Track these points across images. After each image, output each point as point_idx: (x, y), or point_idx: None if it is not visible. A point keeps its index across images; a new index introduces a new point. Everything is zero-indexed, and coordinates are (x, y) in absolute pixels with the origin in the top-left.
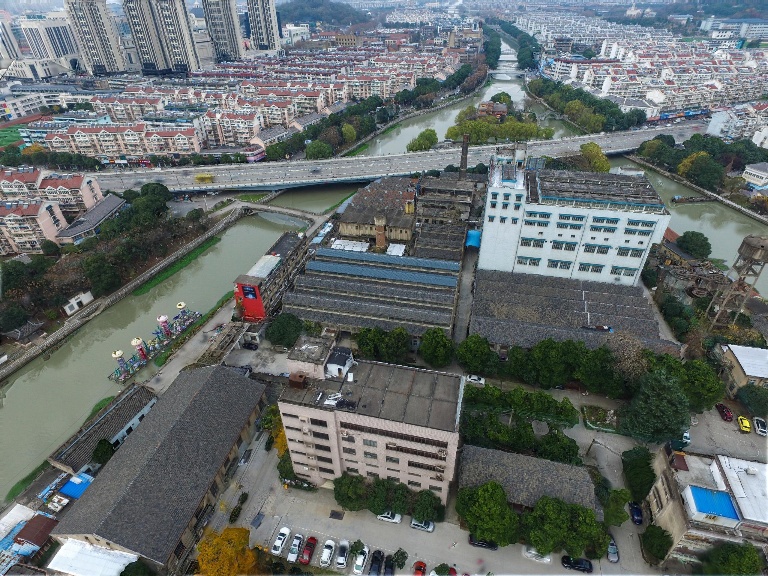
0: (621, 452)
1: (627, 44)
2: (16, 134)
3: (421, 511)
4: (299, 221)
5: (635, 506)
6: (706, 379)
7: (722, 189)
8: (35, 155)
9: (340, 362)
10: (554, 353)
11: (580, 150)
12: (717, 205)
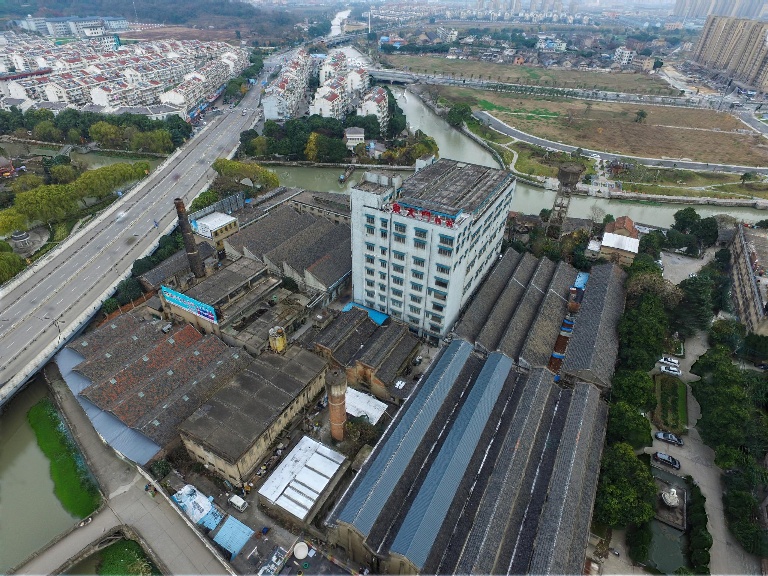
0: (705, 350)
1: (8, 50)
2: None
3: None
4: (72, 570)
5: (767, 366)
6: (658, 269)
7: (349, 158)
8: None
9: None
10: None
11: (224, 171)
12: (357, 172)
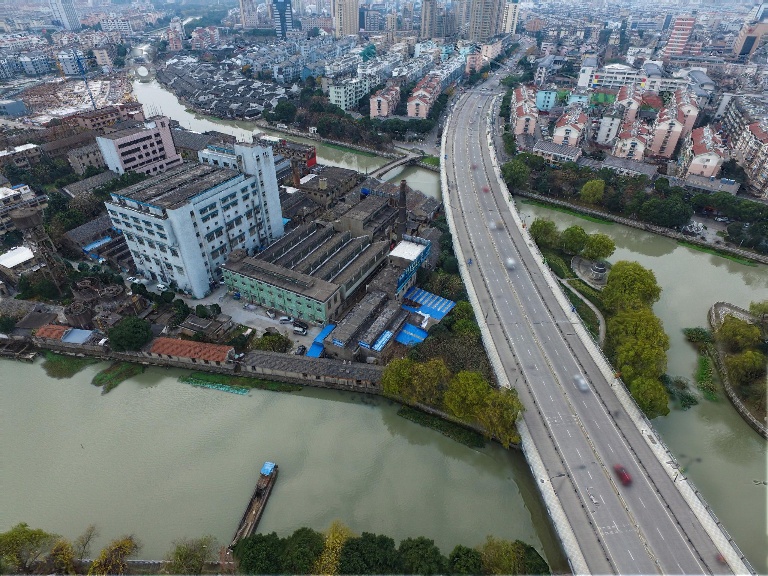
0: None
1: None
2: None
3: None
4: None
5: None
6: None
7: None
8: None
9: None
10: None
11: None
12: None
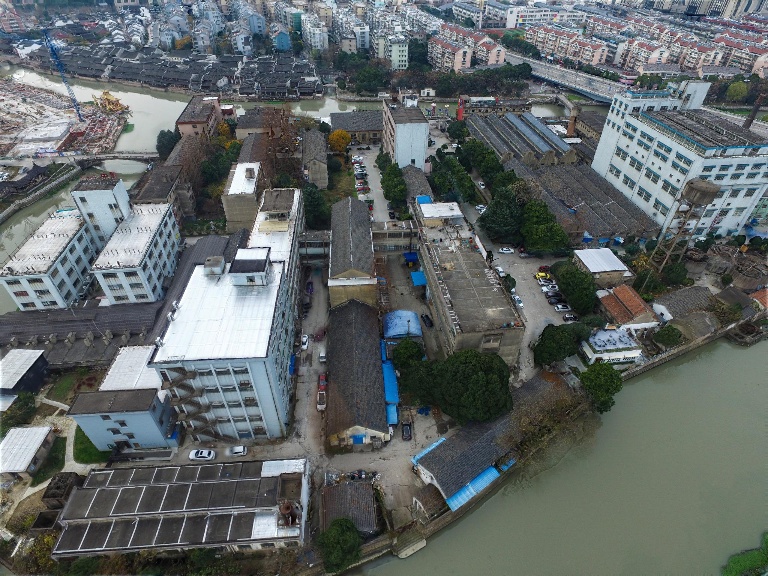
0: None
1: None
2: (524, 27)
3: (384, 171)
4: None
5: None
6: None
7: None
8: (515, 39)
9: (408, 97)
10: (503, 174)
11: None
12: None
